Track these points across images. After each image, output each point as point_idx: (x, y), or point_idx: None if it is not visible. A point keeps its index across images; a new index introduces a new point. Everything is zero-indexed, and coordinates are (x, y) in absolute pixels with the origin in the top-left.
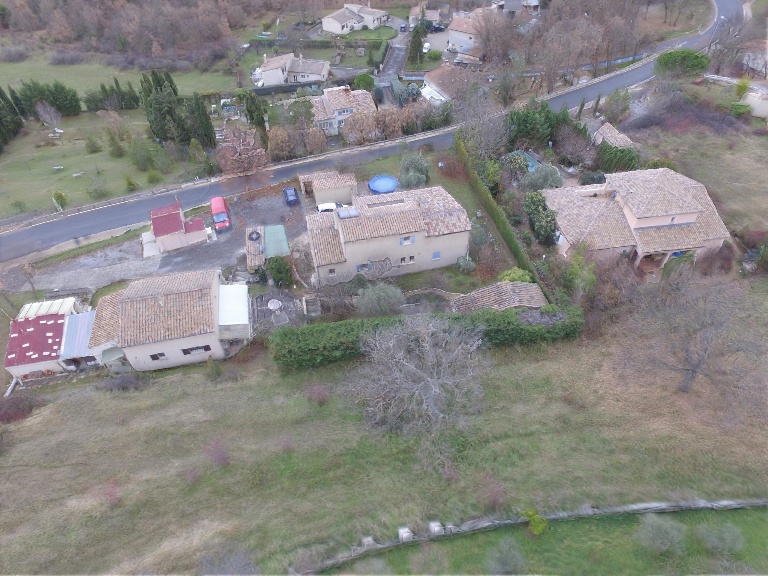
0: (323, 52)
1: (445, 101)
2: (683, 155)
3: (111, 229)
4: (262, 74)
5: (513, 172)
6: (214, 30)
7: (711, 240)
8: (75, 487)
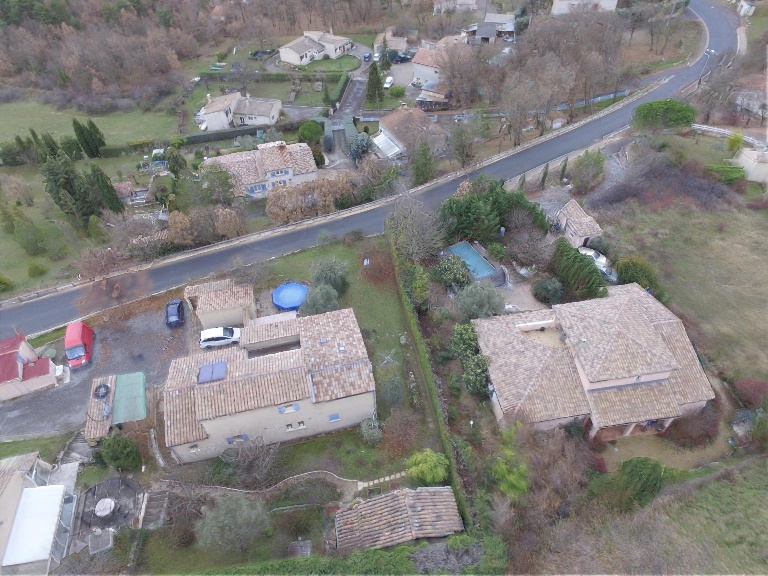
0: (278, 86)
1: (400, 152)
2: (663, 241)
3: None
4: (204, 117)
5: (447, 282)
6: (162, 63)
7: (690, 402)
8: None
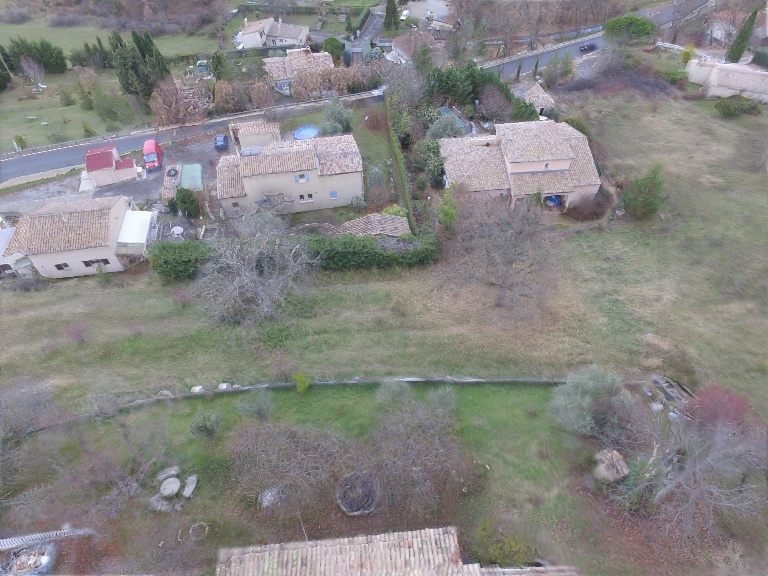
0: (307, 18)
1: None
2: (605, 116)
3: (60, 168)
4: (241, 37)
5: (425, 124)
6: None
7: (583, 187)
8: None
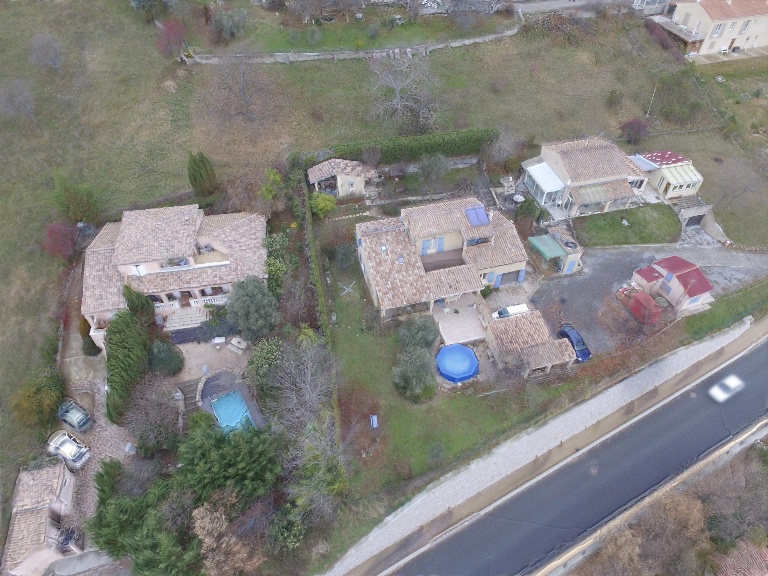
0: None
1: None
2: None
3: None
4: None
5: None
6: None
7: None
8: (557, 88)
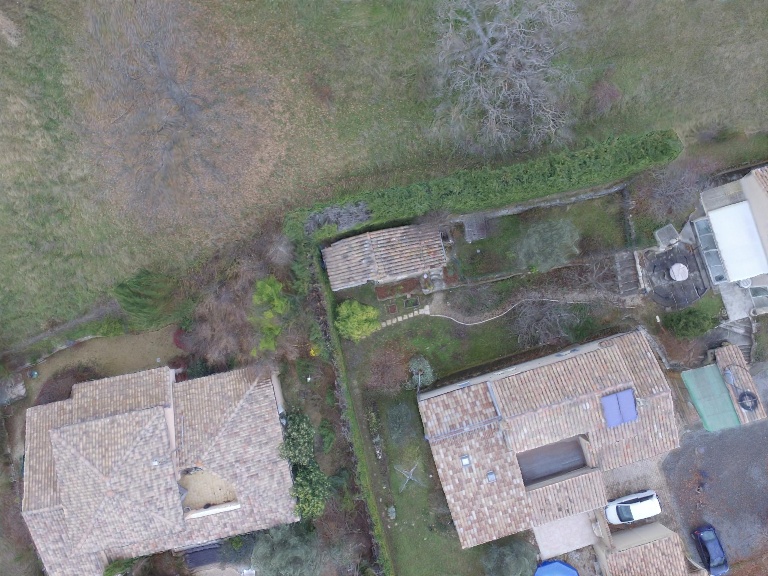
0: None
1: None
2: None
3: None
4: None
5: None
6: None
7: None
8: None
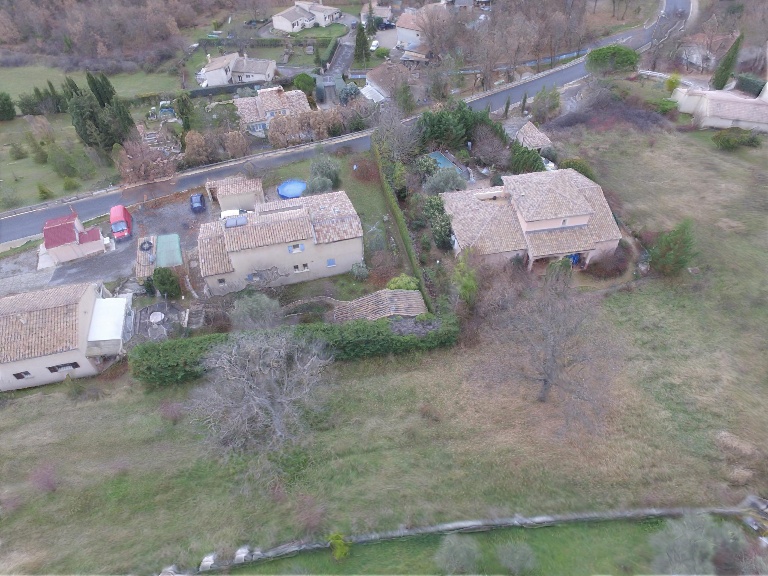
0: (272, 51)
1: (384, 100)
2: (603, 153)
3: (13, 240)
4: (205, 74)
5: (422, 175)
6: (162, 30)
7: (604, 242)
8: None
